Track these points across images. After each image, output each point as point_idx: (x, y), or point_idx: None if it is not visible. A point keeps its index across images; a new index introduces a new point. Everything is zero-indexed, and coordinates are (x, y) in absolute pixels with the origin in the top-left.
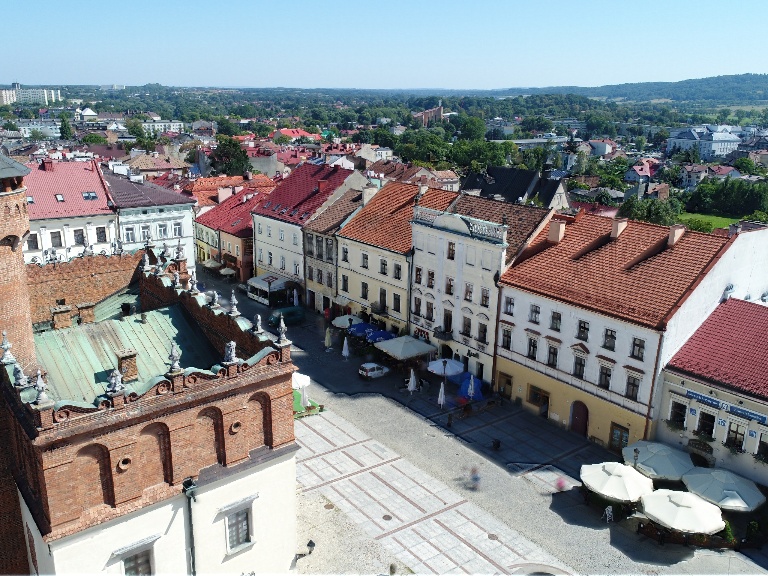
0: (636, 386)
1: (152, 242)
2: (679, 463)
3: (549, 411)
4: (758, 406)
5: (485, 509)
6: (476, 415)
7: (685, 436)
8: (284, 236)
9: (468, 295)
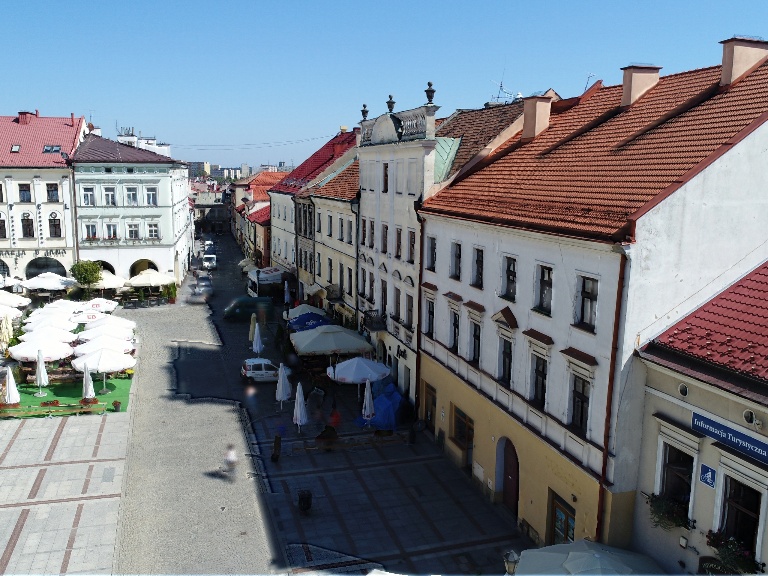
0: (585, 399)
1: (117, 208)
2: None
3: None
4: None
5: None
6: (347, 450)
7: (690, 545)
8: (286, 214)
9: (399, 249)
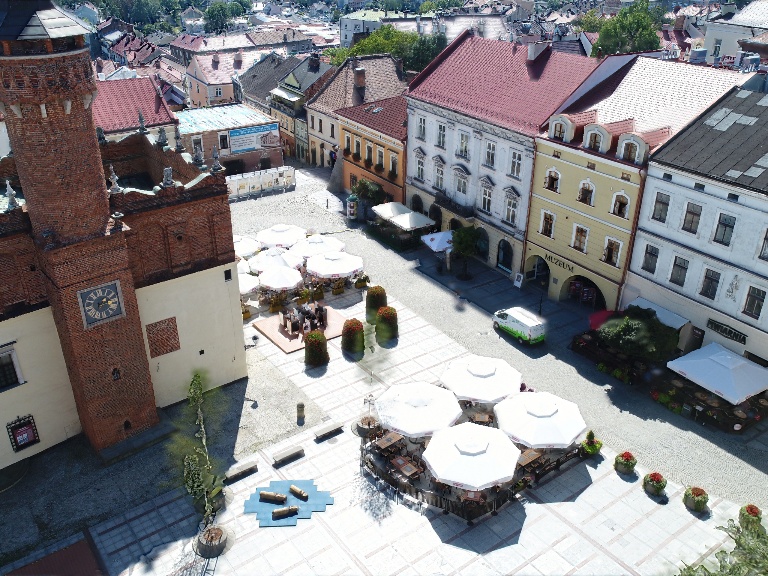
0: None
1: None
2: None
3: None
4: (151, 132)
5: None
6: None
7: None
8: None
9: None
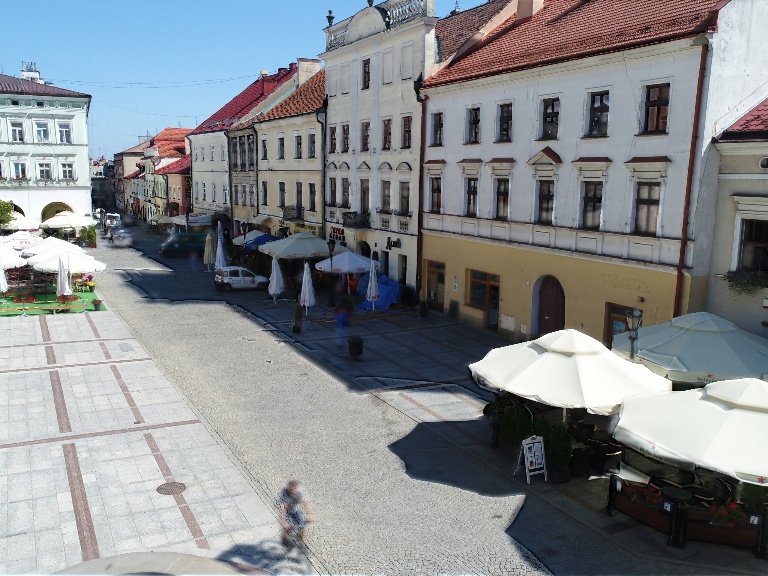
0: (653, 202)
1: (26, 145)
2: (754, 351)
3: (498, 313)
4: None
5: (222, 437)
6: (364, 324)
7: None
8: (214, 153)
9: (387, 141)
